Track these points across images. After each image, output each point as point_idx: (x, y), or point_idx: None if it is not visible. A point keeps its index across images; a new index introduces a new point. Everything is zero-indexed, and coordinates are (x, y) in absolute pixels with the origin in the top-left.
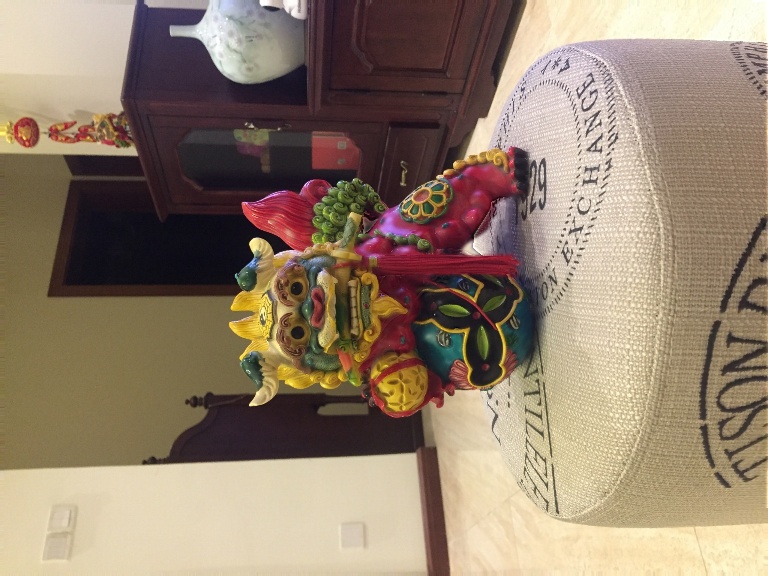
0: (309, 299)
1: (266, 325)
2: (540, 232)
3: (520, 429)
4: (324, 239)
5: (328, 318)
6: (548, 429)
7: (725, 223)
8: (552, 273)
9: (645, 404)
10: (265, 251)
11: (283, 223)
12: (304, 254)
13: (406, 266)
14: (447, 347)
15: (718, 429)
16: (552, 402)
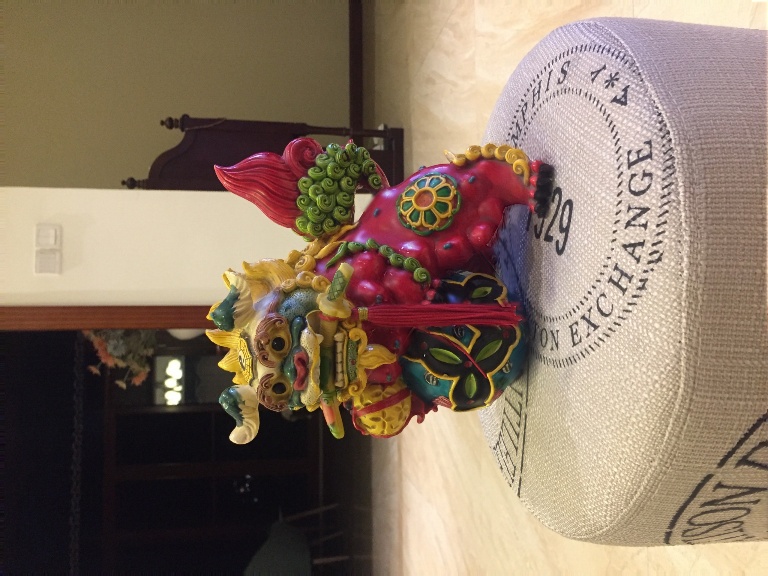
0: (292, 364)
1: (245, 373)
2: (551, 275)
3: (496, 419)
4: (309, 229)
5: (311, 383)
6: (522, 453)
7: (751, 389)
8: (555, 333)
9: (619, 514)
10: (243, 290)
11: (263, 202)
12: (287, 287)
13: (399, 321)
14: (434, 385)
15: (682, 533)
16: (531, 440)
